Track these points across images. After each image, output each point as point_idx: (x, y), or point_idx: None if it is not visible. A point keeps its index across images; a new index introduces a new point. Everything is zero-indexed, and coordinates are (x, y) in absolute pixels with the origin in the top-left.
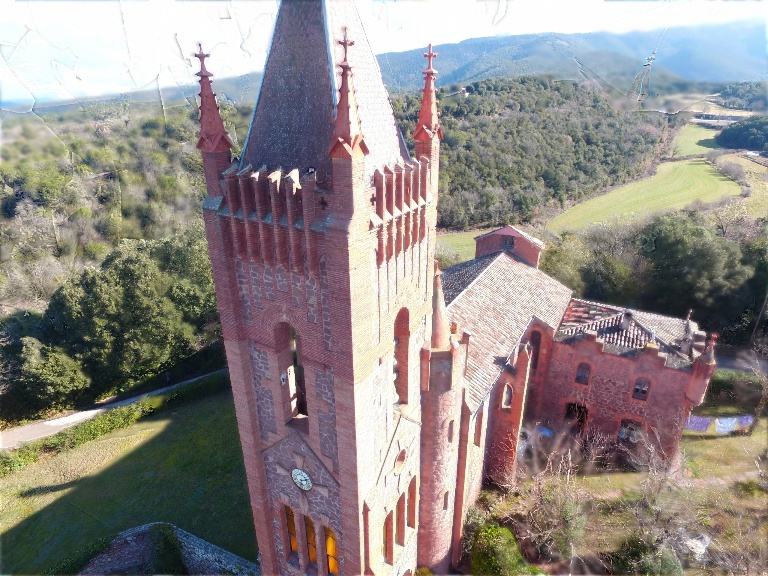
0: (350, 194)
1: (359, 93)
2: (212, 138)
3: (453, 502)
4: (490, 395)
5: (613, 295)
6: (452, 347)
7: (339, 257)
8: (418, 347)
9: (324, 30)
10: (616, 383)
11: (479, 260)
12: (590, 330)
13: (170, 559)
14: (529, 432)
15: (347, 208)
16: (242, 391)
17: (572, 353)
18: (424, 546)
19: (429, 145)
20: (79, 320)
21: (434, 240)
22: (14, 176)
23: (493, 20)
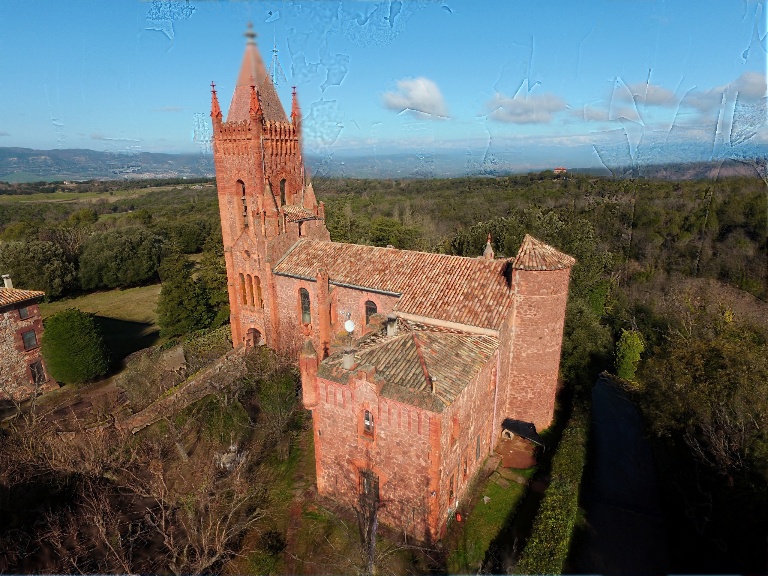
0: None
1: None
2: None
3: None
4: None
5: None
6: None
7: None
8: (254, 207)
9: None
10: None
11: None
12: None
13: None
14: None
15: None
16: None
17: None
18: None
19: None
20: None
21: (258, 159)
22: (593, 183)
23: None
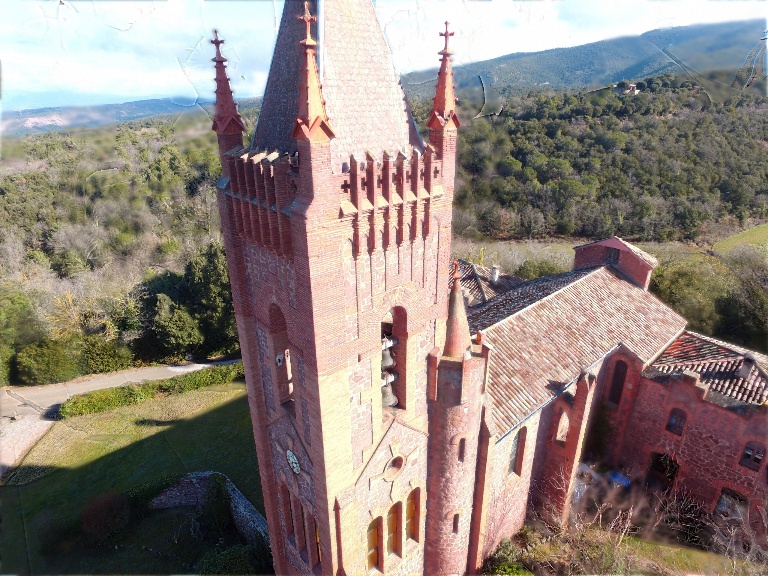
0: (310, 178)
1: (355, 75)
2: (223, 120)
3: (467, 527)
4: (540, 422)
5: (759, 335)
6: (463, 358)
7: (301, 243)
8: (424, 352)
9: (316, 10)
10: (719, 441)
11: (575, 272)
12: (691, 371)
13: (220, 507)
14: (595, 475)
15: (309, 193)
16: (248, 365)
17: (664, 394)
18: (431, 565)
19: (441, 133)
20: (200, 285)
21: (449, 239)
22: (185, 160)
23: (656, 4)
